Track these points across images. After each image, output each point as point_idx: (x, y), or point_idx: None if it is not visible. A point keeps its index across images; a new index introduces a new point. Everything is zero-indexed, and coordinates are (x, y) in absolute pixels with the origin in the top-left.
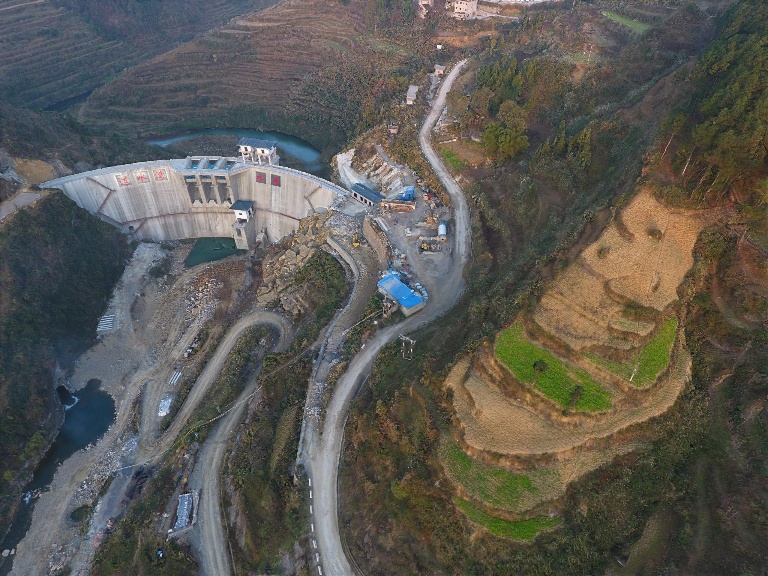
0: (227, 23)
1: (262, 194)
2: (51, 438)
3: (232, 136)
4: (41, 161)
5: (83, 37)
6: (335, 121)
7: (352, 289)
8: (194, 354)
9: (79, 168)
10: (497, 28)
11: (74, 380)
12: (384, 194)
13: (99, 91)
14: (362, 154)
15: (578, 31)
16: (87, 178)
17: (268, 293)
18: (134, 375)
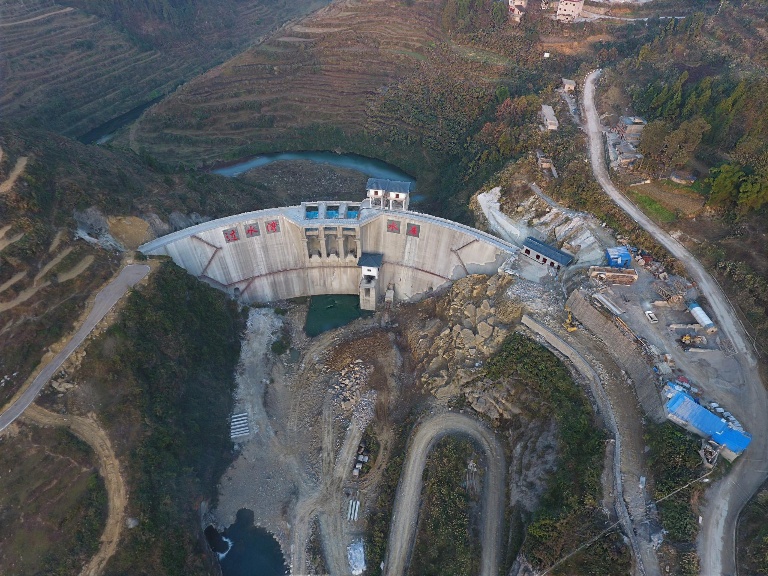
0: (280, 29)
1: (393, 245)
2: None
3: (310, 161)
4: (136, 217)
5: (119, 48)
6: (428, 142)
7: (591, 397)
8: (367, 472)
9: (174, 220)
10: (609, 31)
11: (220, 513)
12: (568, 251)
13: (151, 112)
14: (513, 195)
15: (764, 40)
16: (192, 236)
17: (446, 386)
18: (297, 505)
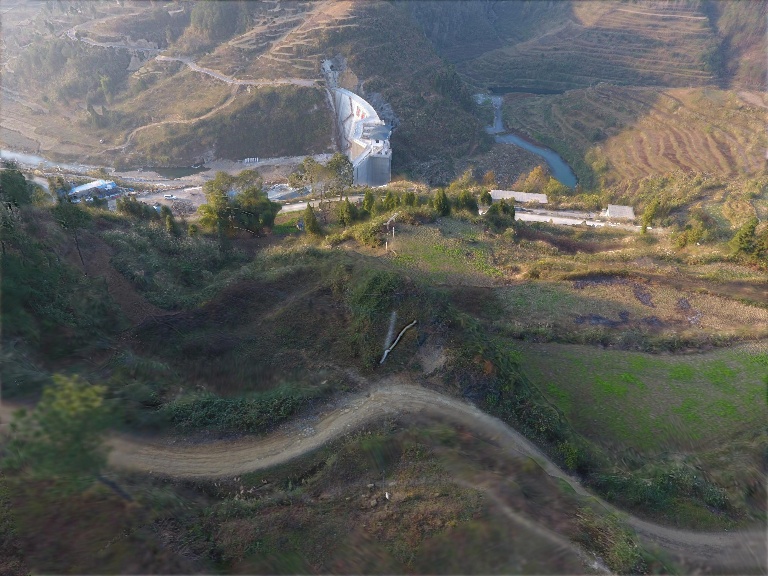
0: None
1: None
2: (172, 165)
3: (544, 169)
4: (357, 77)
5: (679, 57)
6: None
7: None
8: None
9: (374, 96)
10: None
11: (211, 163)
12: None
13: None
14: None
15: None
16: (349, 97)
17: None
18: (200, 176)
